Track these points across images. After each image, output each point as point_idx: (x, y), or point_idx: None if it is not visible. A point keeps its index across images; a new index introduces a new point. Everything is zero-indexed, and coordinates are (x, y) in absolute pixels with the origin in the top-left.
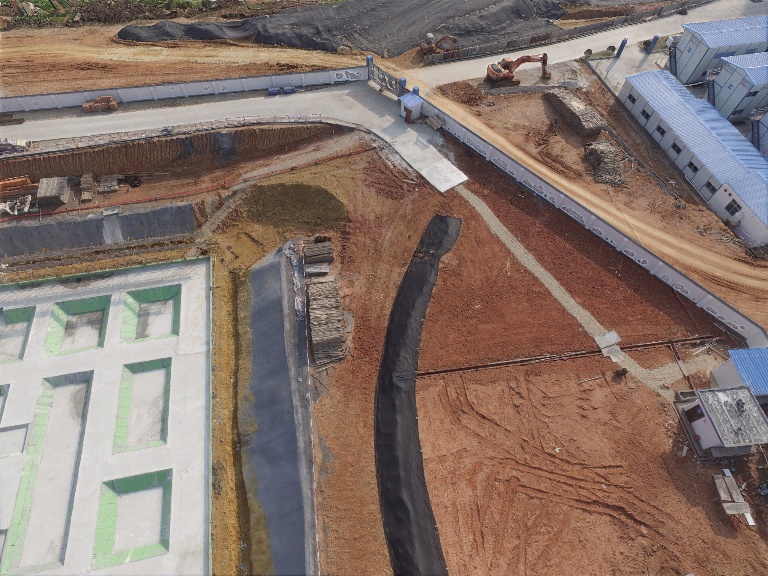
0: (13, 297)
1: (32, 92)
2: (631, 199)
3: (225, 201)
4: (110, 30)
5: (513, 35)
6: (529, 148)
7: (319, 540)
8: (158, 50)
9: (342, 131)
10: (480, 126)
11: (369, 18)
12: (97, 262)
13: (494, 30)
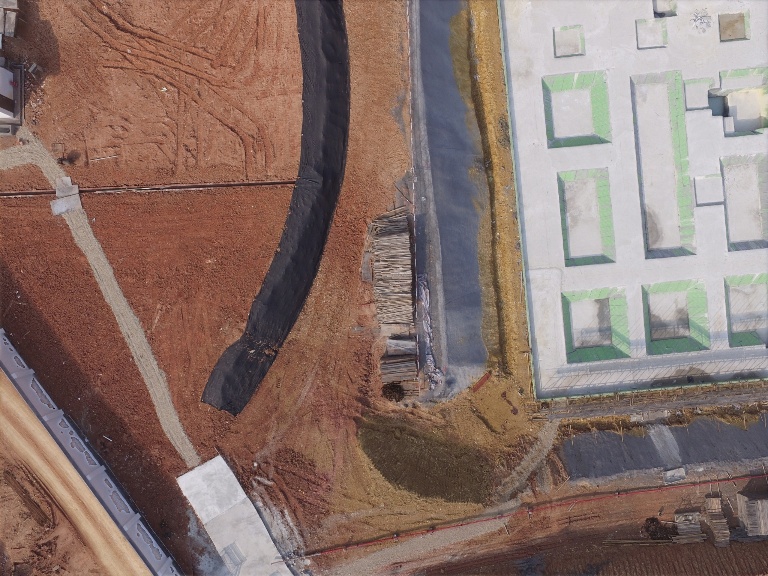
0: (760, 362)
1: None
2: None
3: (526, 484)
4: None
5: None
6: (68, 538)
7: (407, 40)
8: None
9: None
10: None
11: None
12: None
13: None
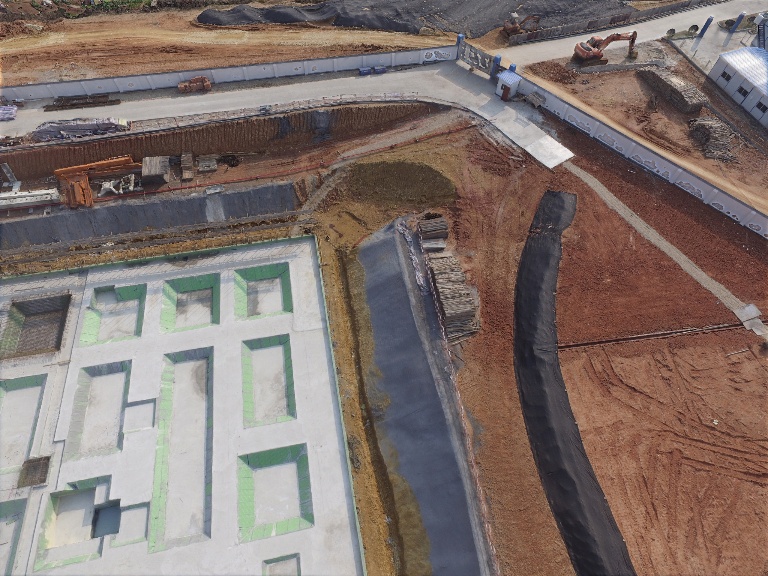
0: (123, 275)
1: (123, 74)
2: (744, 174)
3: (325, 180)
4: (188, 15)
5: (590, 16)
6: (631, 125)
7: (484, 511)
8: (240, 33)
9: (438, 110)
10: (578, 104)
11: (446, 0)
12: (201, 241)
13: (571, 11)
